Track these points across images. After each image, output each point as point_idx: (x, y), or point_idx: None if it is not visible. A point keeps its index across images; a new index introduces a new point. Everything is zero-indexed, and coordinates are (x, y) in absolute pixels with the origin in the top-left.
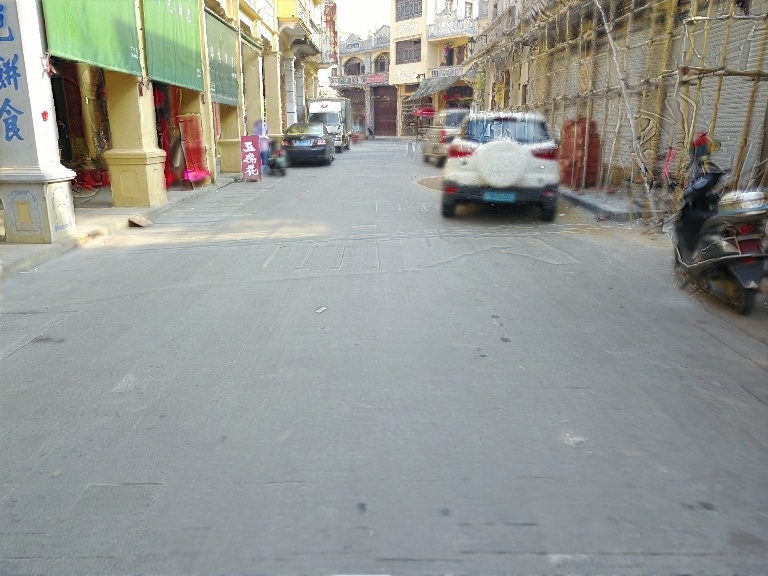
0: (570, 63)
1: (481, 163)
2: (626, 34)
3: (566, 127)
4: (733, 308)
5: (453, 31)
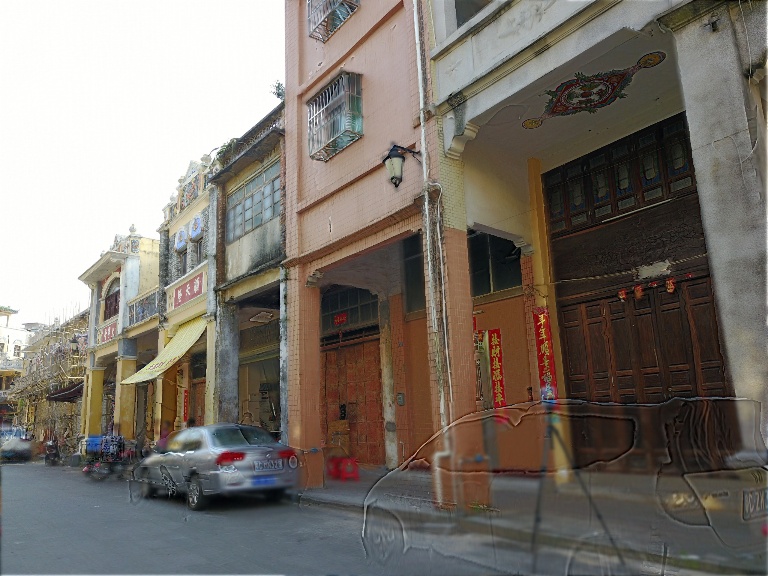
0: (47, 407)
1: (6, 448)
2: (57, 402)
3: (45, 431)
4: (51, 464)
5: (3, 367)
